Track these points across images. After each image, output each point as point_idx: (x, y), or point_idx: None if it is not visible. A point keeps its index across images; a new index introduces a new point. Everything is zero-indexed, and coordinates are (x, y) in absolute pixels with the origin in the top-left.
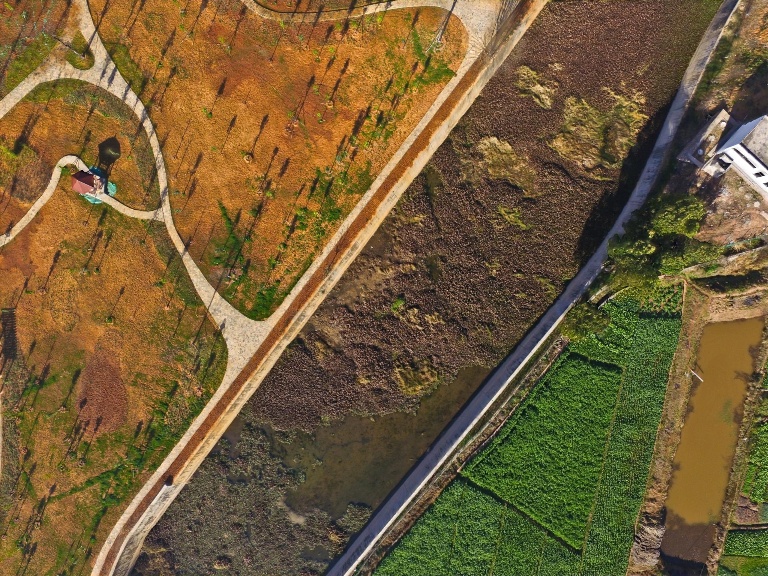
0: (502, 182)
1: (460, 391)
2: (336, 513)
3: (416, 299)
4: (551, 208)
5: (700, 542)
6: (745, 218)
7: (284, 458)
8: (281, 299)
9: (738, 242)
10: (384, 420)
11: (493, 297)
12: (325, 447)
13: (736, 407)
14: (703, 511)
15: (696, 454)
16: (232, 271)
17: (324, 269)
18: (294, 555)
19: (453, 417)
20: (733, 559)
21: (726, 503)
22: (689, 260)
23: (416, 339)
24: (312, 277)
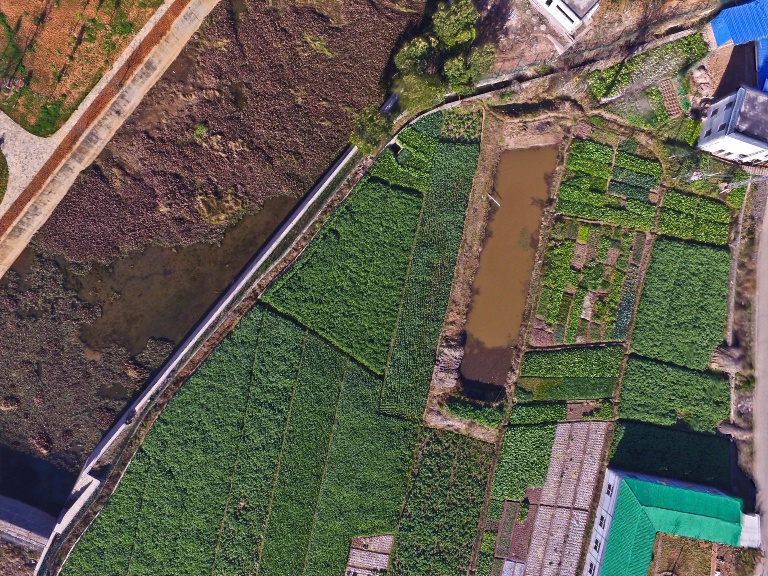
0: (308, 10)
1: (267, 222)
2: (136, 349)
3: (220, 126)
4: (357, 37)
5: (499, 365)
6: (532, 41)
7: (79, 291)
8: (68, 115)
9: (529, 67)
10: (187, 251)
11: (299, 125)
12: (124, 280)
13: (532, 232)
14: (502, 335)
15: (495, 279)
16: (11, 82)
17: (115, 85)
18: (89, 393)
19: (259, 248)
20: (529, 380)
21: (522, 325)
22: (473, 72)
23: (219, 166)
24: (102, 92)
